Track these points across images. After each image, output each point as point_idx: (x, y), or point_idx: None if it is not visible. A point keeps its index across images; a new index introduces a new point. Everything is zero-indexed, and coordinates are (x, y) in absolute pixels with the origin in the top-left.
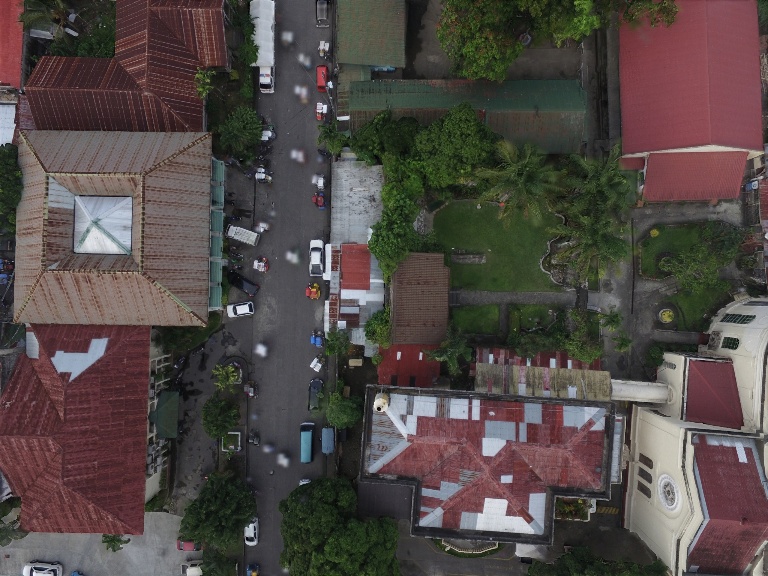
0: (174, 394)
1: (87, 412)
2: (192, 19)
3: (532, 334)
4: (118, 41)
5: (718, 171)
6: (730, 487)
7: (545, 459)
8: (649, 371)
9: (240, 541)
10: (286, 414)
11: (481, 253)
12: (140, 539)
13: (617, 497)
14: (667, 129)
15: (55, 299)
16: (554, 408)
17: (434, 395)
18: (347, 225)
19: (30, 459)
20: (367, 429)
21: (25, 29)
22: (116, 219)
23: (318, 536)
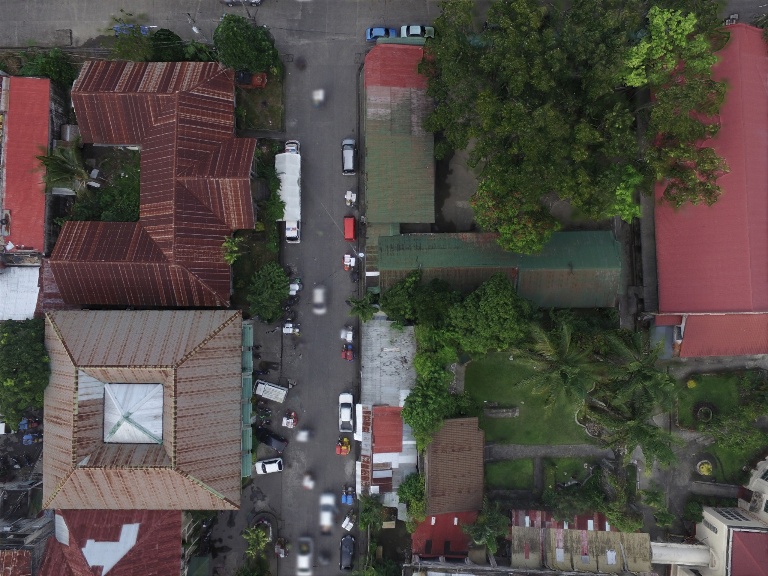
0: (204, 560)
1: None
2: (219, 188)
3: (569, 497)
4: (143, 205)
5: (758, 329)
6: None
7: None
8: (687, 524)
9: None
10: (317, 571)
11: (514, 406)
12: None
13: None
14: (706, 290)
15: (85, 490)
16: None
17: (472, 572)
18: (378, 386)
19: None
20: None
21: (47, 190)
22: (147, 410)
23: None
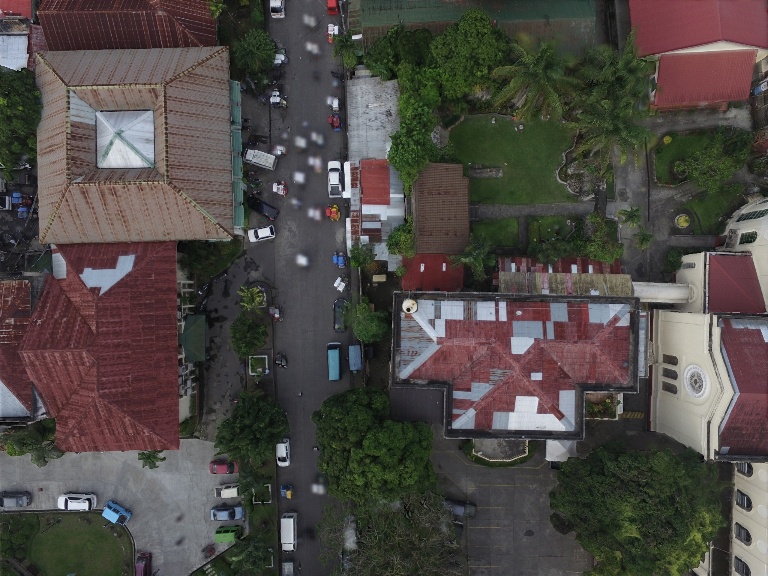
0: (200, 317)
1: (118, 326)
2: None
3: (553, 240)
4: None
5: (728, 71)
6: (757, 364)
7: (573, 355)
8: (668, 276)
9: (272, 463)
10: (312, 336)
11: (498, 167)
12: (172, 466)
13: (642, 401)
14: (677, 30)
15: (81, 215)
16: (579, 306)
17: (460, 299)
18: (365, 141)
19: (64, 375)
20: (396, 336)
21: None
22: (138, 132)
23: (355, 433)
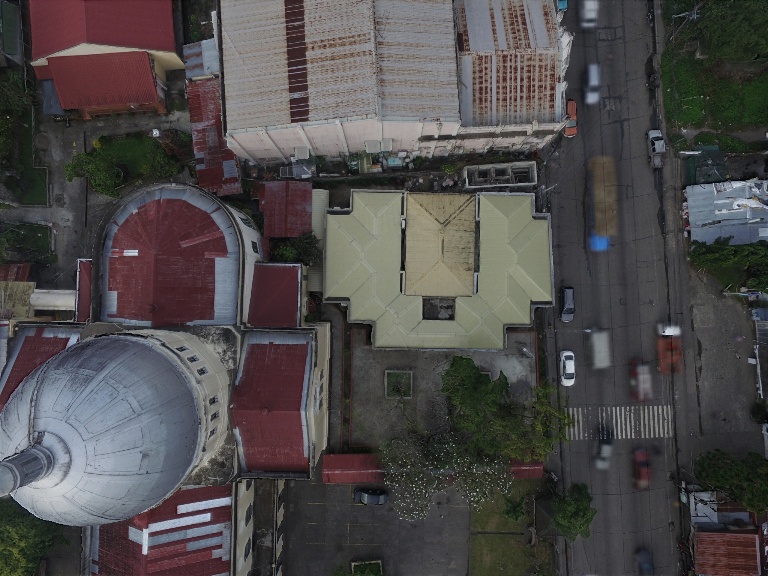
0: None
1: None
2: None
3: None
4: None
5: (126, 74)
6: None
7: None
8: None
9: None
10: None
11: None
12: None
13: None
14: (60, 33)
15: None
16: None
17: None
18: None
19: None
20: None
21: None
22: None
23: None
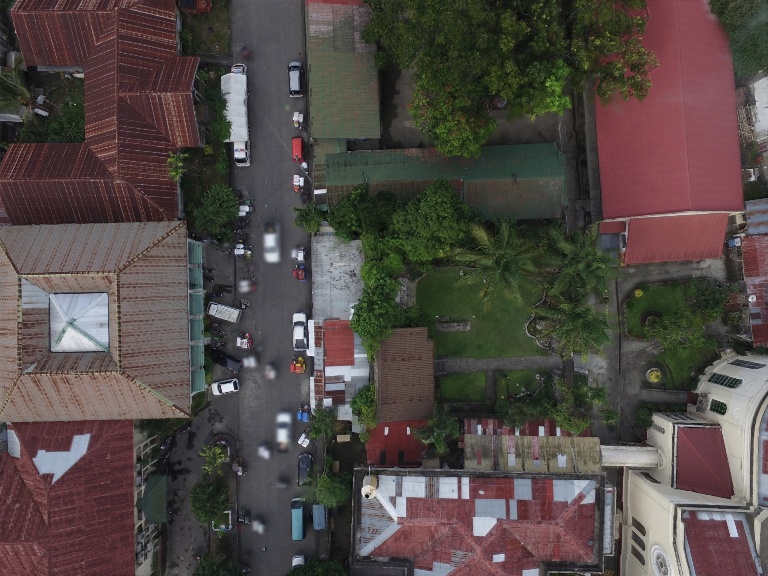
0: (161, 478)
1: (72, 513)
2: (162, 103)
3: (519, 403)
4: (88, 126)
5: (700, 232)
6: (721, 565)
7: (536, 535)
8: (639, 431)
9: None
10: (276, 490)
11: (465, 320)
12: None
13: (612, 559)
14: (647, 194)
15: (34, 400)
16: (544, 483)
17: (422, 475)
18: (329, 301)
19: (16, 563)
20: (356, 512)
21: None
22: (92, 317)
23: None
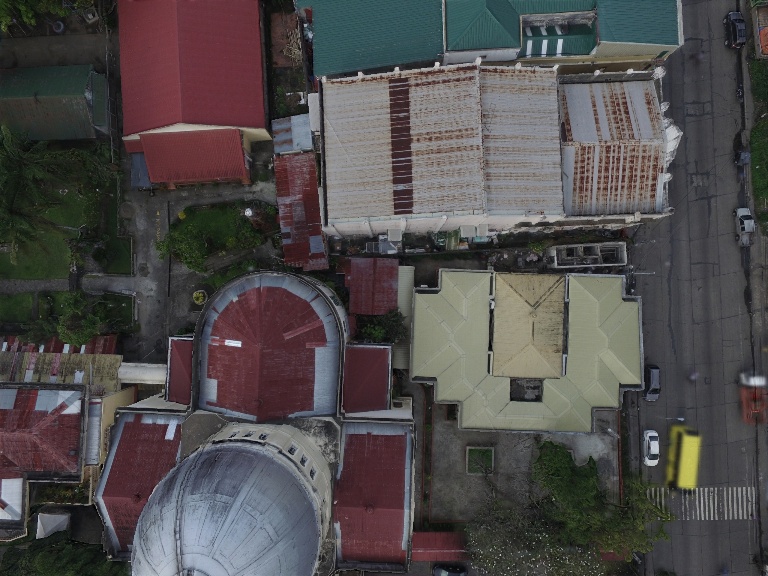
0: None
1: None
2: None
3: (40, 320)
4: None
5: (216, 149)
6: (141, 464)
7: (14, 444)
8: None
9: None
10: None
11: None
12: None
13: None
14: (153, 109)
15: None
16: (29, 393)
17: None
18: None
19: None
20: None
21: None
22: None
23: None
